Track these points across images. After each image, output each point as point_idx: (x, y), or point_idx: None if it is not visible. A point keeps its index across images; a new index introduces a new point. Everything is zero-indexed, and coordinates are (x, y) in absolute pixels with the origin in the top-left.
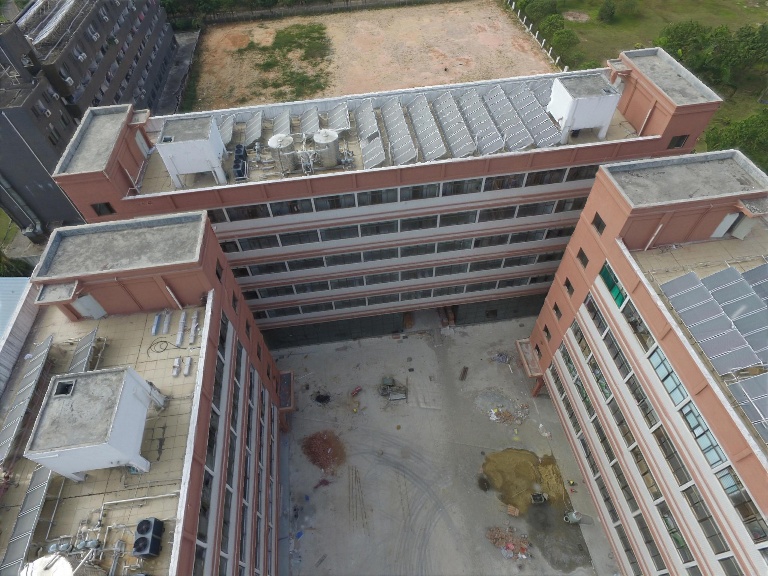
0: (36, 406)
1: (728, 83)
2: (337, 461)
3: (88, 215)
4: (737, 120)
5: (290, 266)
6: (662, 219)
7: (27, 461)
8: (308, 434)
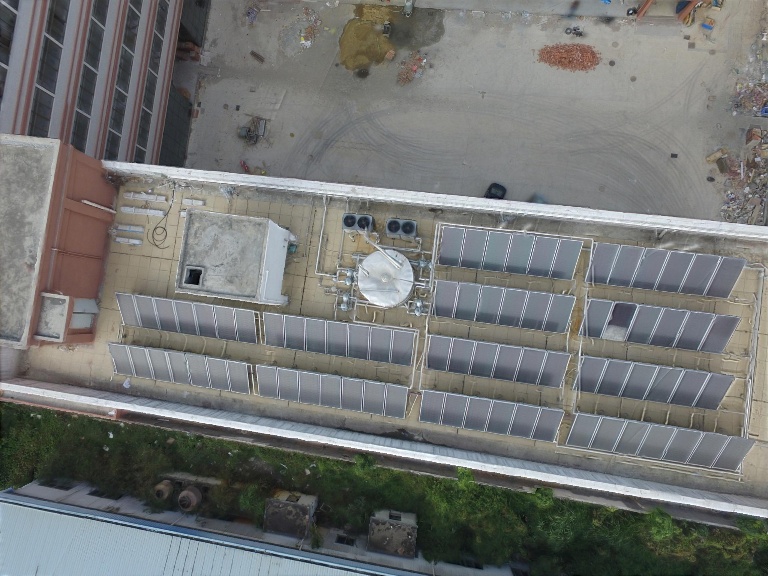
0: None
1: None
2: None
3: None
4: None
5: None
6: None
7: (252, 358)
8: None
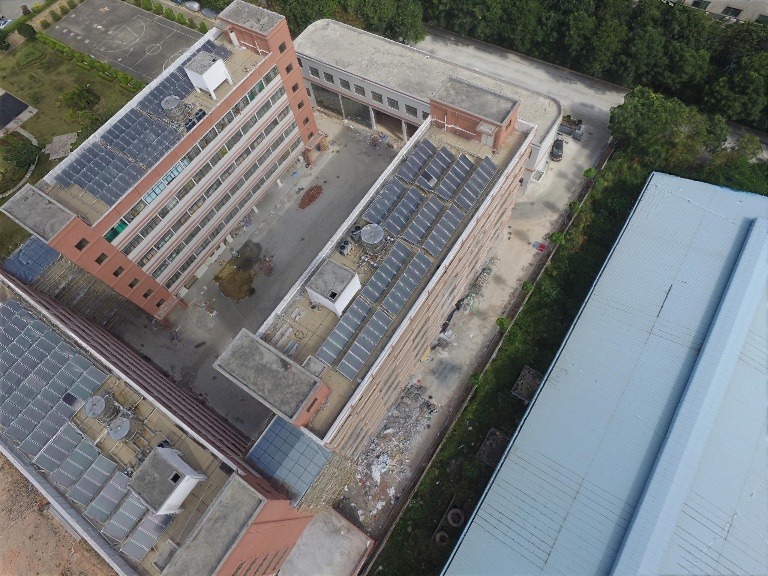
0: None
1: None
2: None
3: (277, 498)
4: None
5: None
6: None
7: None
8: None
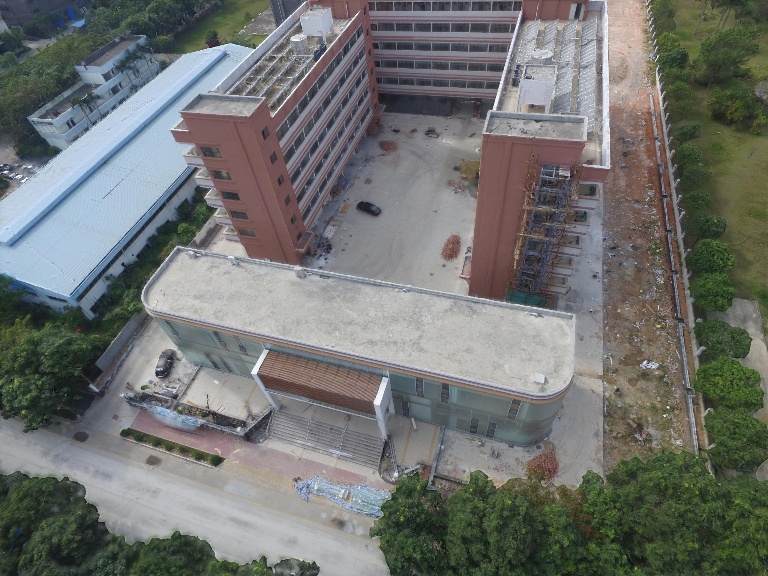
0: (298, 30)
1: (753, 16)
2: (392, 150)
3: None
4: (766, 51)
5: (398, 46)
6: (539, 1)
7: None
8: (384, 140)
